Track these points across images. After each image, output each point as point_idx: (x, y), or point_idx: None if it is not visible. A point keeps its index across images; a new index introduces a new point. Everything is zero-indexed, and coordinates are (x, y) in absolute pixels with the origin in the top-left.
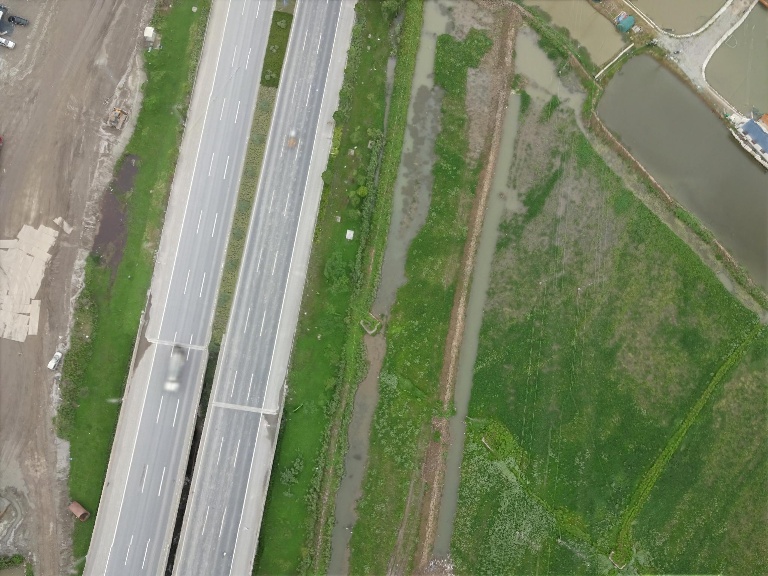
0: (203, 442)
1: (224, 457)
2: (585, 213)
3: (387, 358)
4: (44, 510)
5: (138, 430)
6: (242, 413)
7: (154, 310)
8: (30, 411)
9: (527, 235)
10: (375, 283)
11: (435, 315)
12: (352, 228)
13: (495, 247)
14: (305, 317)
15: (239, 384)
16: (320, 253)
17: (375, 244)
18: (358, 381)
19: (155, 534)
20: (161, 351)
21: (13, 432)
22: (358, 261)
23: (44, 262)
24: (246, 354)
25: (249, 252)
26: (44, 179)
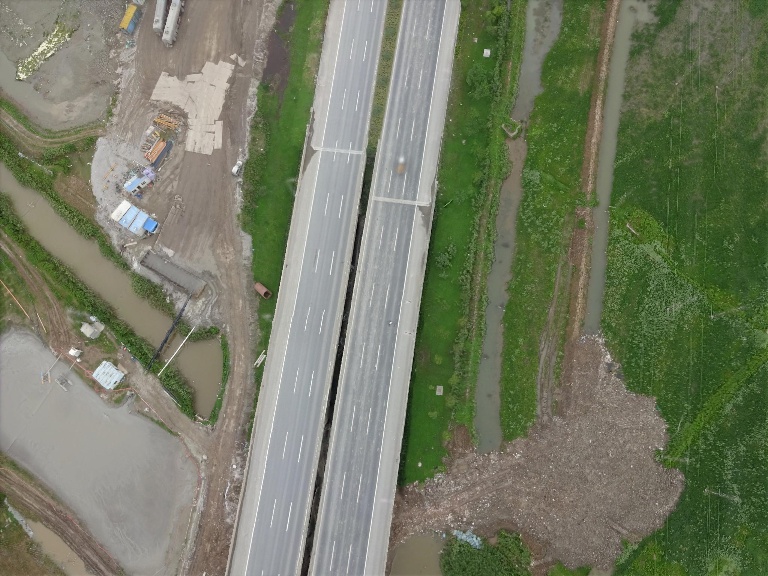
0: (366, 230)
1: (385, 242)
2: (718, 18)
3: (529, 157)
4: (234, 289)
5: (309, 222)
6: (399, 205)
7: (317, 124)
8: (219, 210)
9: (660, 42)
10: (514, 91)
11: (573, 117)
12: (489, 47)
13: (628, 55)
14: (450, 123)
15: (395, 181)
16: (461, 68)
17: (512, 57)
18: (503, 177)
19: (329, 306)
20: (325, 157)
21: (206, 227)
22: (496, 73)
23: (224, 90)
24: (399, 156)
25: (397, 71)
26: (220, 24)
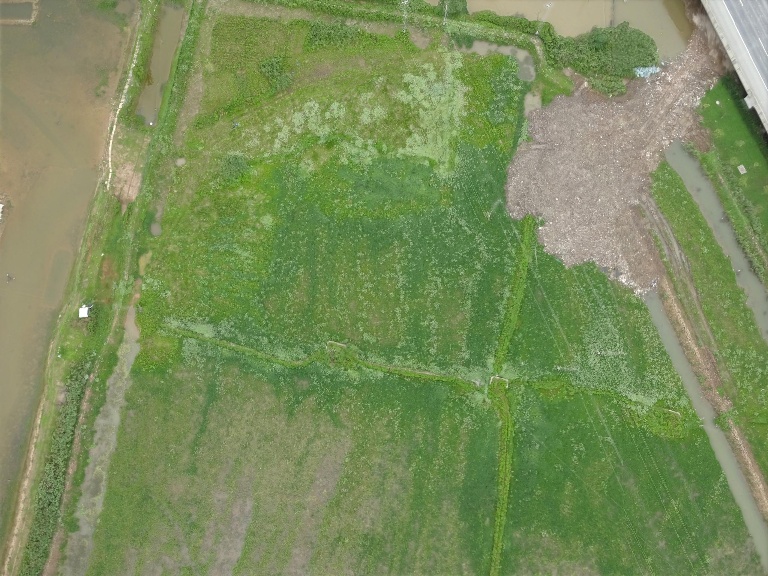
0: None
1: None
2: None
3: None
4: None
5: None
6: None
7: None
8: None
9: None
10: None
11: None
12: None
13: None
14: None
15: None
16: None
17: None
18: None
19: None
20: None
21: None
22: None
23: None
24: None
25: None
26: None
